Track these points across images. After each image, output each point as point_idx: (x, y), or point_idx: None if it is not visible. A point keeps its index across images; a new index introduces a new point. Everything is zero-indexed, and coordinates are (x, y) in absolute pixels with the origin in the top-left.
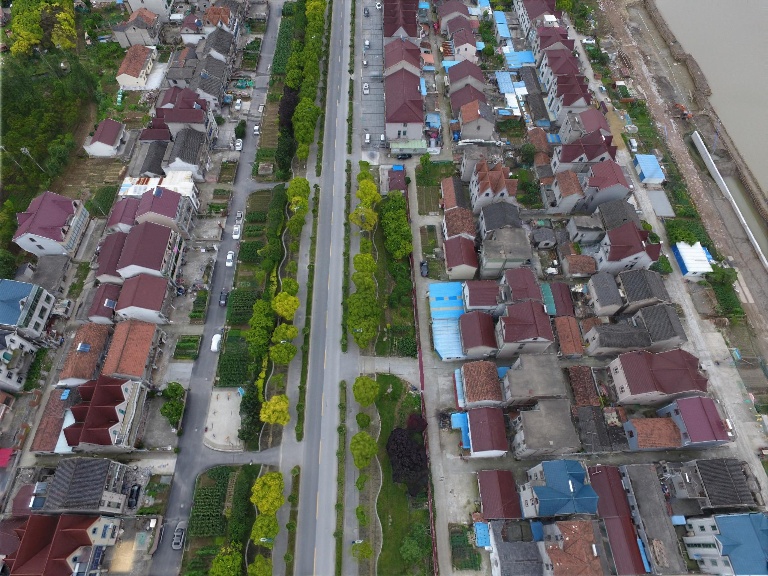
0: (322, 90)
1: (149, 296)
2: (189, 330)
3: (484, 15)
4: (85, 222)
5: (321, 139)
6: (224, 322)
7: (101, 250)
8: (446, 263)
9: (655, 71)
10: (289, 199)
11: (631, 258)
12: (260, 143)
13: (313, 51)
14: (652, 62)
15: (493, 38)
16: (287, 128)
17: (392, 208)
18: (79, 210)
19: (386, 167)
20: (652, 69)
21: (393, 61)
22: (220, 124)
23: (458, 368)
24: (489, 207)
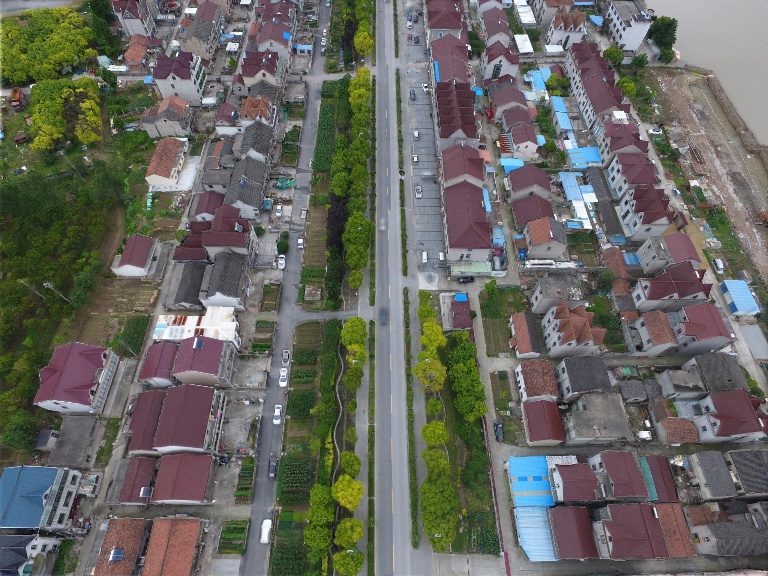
0: (372, 197)
1: (191, 482)
2: (234, 512)
3: (541, 101)
4: (114, 370)
5: (373, 257)
6: (274, 501)
7: (134, 412)
8: (527, 430)
9: (728, 165)
10: (343, 342)
11: (743, 434)
12: (305, 259)
13: (361, 150)
14: (723, 154)
15: (552, 128)
16: (337, 248)
17: (462, 358)
18: (109, 360)
19: (447, 294)
20: (724, 163)
21: (454, 173)
22: (260, 235)
23: (548, 570)
24: (573, 360)
